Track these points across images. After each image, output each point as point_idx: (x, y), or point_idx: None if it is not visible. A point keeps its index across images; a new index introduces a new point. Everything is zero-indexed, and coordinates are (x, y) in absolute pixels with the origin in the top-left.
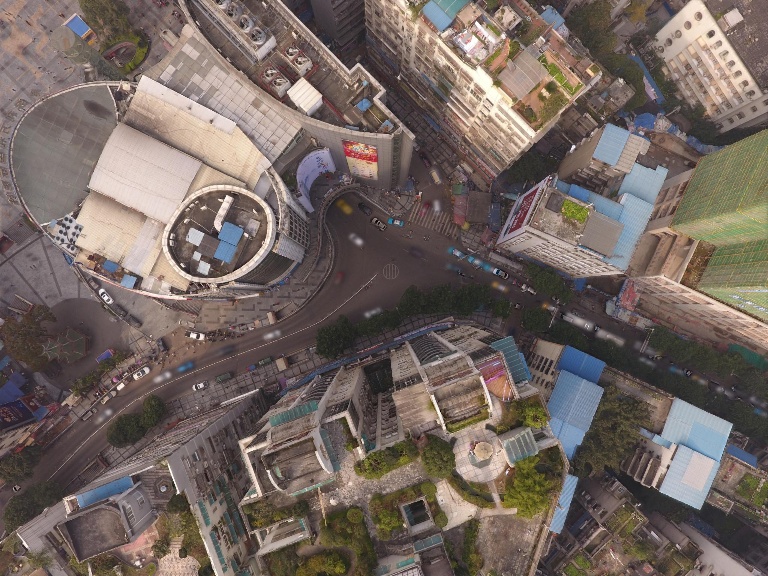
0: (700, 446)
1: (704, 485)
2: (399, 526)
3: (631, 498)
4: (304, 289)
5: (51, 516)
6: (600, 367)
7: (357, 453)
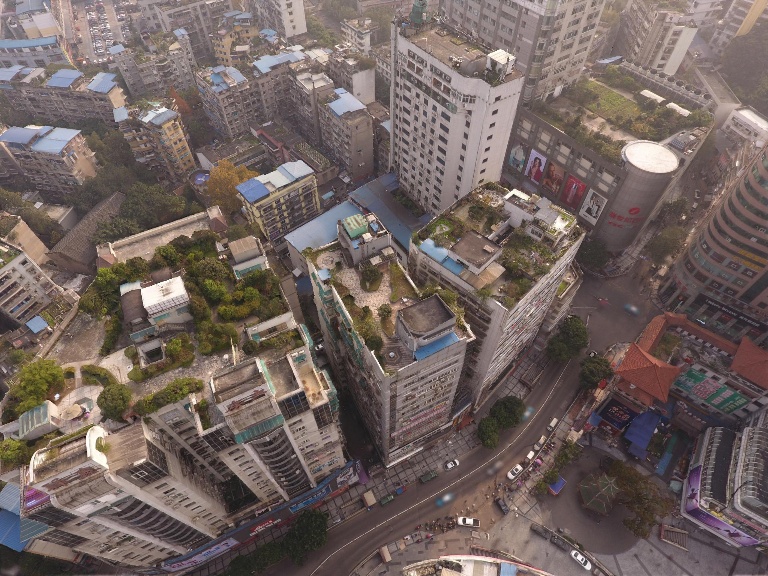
0: None
1: None
2: None
3: None
4: None
5: (498, 327)
6: None
7: (199, 399)
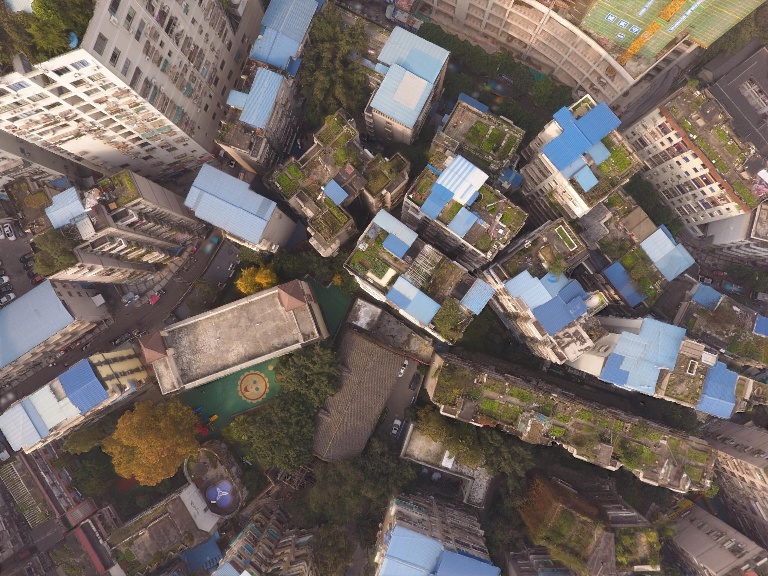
0: (415, 69)
1: (416, 105)
2: None
3: (346, 115)
4: None
5: None
6: None
7: None
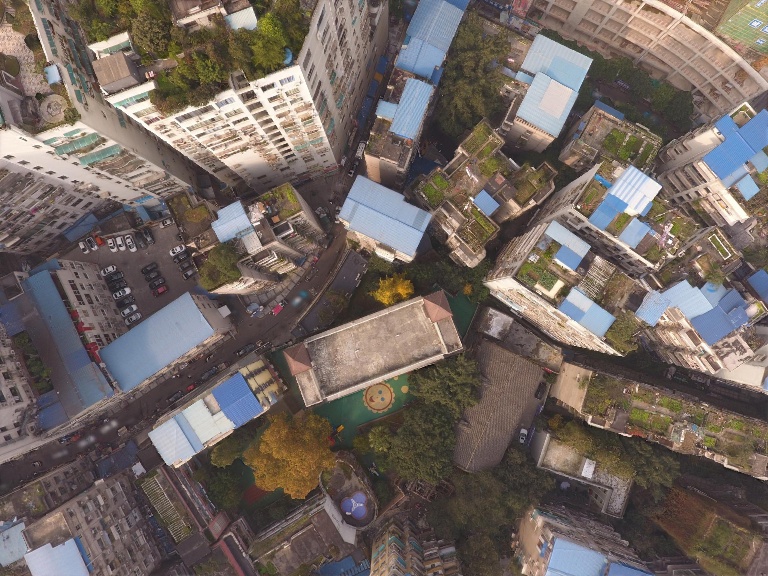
0: (559, 77)
1: (562, 113)
2: None
3: (490, 125)
4: None
5: None
6: (465, 2)
7: None
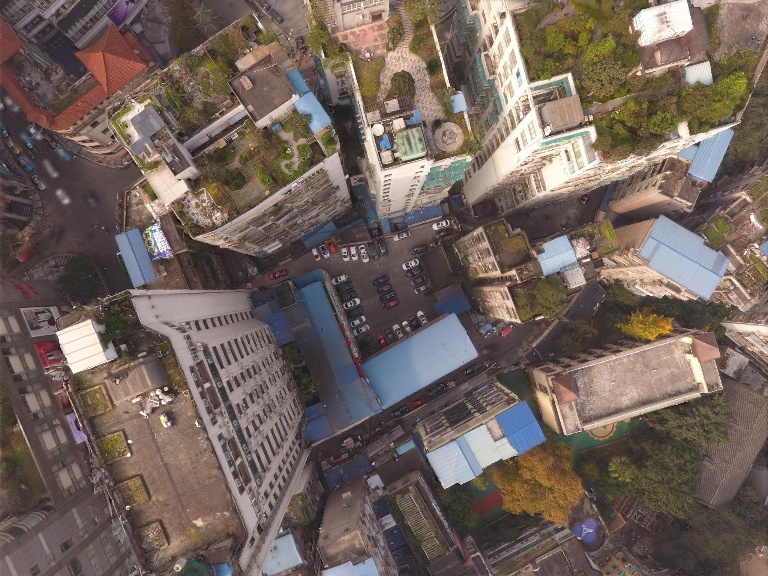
0: None
1: None
2: (643, 3)
3: None
4: (446, 3)
5: None
6: None
7: None
